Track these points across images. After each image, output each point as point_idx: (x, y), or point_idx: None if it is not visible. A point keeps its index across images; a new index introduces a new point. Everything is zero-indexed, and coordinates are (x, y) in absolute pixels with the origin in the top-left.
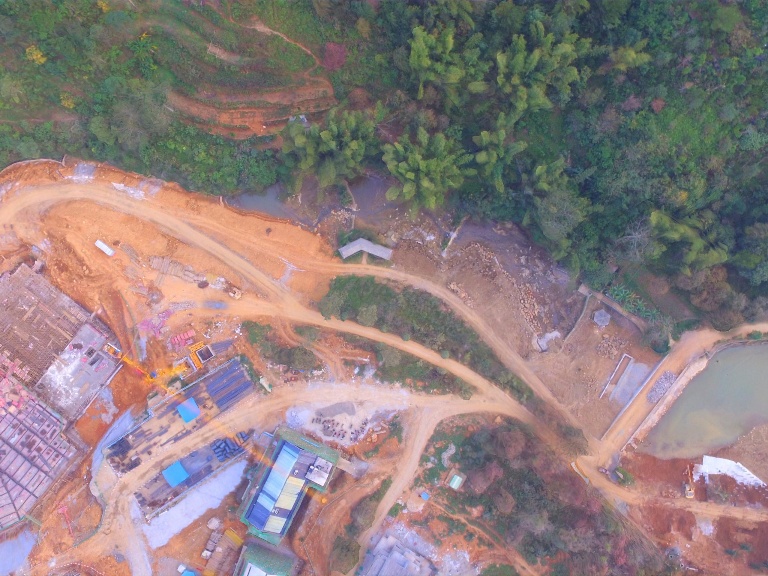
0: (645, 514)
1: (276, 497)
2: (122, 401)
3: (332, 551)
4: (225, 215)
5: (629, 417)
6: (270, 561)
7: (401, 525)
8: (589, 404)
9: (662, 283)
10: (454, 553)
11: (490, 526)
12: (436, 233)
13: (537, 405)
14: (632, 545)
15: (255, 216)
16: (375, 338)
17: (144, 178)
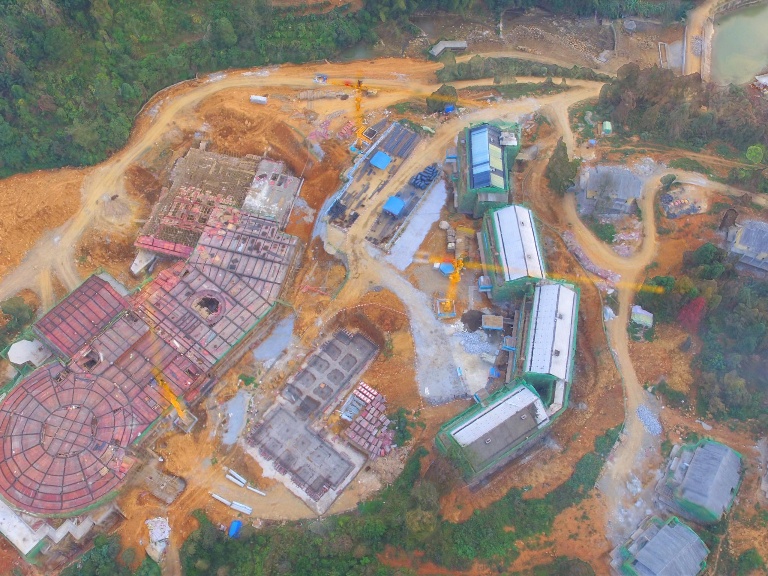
0: None
1: (488, 160)
2: (317, 197)
3: (548, 206)
4: None
5: (690, 68)
6: None
7: (588, 167)
8: None
9: None
10: (639, 161)
11: (651, 142)
12: (488, 29)
13: None
14: None
15: (356, 62)
16: (488, 84)
17: (263, 67)
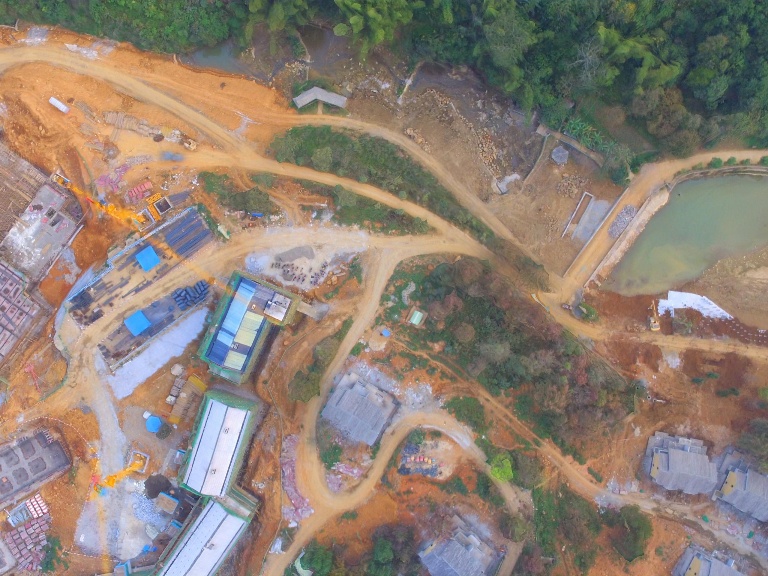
0: (610, 348)
1: (235, 332)
2: (84, 259)
3: None
4: (179, 72)
5: (591, 253)
6: (233, 399)
7: (363, 363)
8: (551, 244)
9: (617, 110)
10: (416, 386)
11: (452, 360)
12: (391, 81)
13: (497, 243)
14: (594, 368)
15: (209, 72)
16: (332, 184)
17: (97, 39)
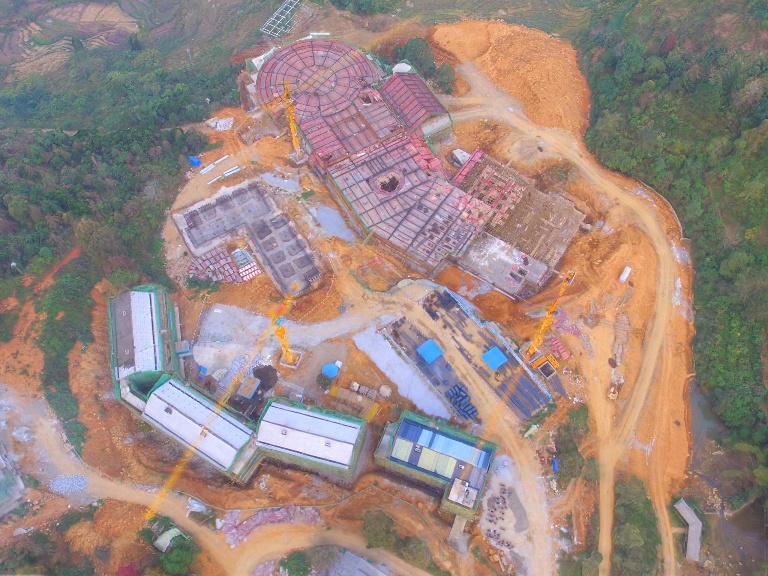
0: None
1: (433, 447)
2: (483, 301)
3: None
4: (680, 379)
5: None
6: None
7: None
8: None
9: None
10: None
11: None
12: None
13: None
14: None
15: (686, 408)
16: (601, 549)
17: (691, 304)
